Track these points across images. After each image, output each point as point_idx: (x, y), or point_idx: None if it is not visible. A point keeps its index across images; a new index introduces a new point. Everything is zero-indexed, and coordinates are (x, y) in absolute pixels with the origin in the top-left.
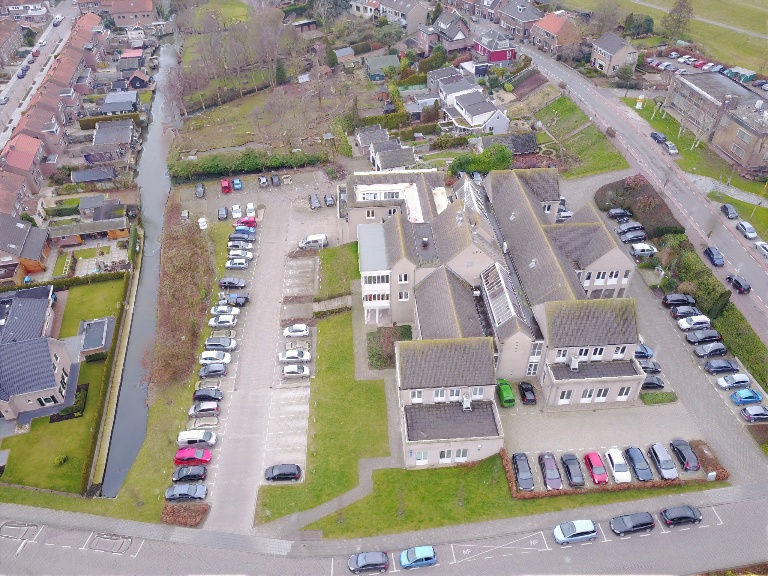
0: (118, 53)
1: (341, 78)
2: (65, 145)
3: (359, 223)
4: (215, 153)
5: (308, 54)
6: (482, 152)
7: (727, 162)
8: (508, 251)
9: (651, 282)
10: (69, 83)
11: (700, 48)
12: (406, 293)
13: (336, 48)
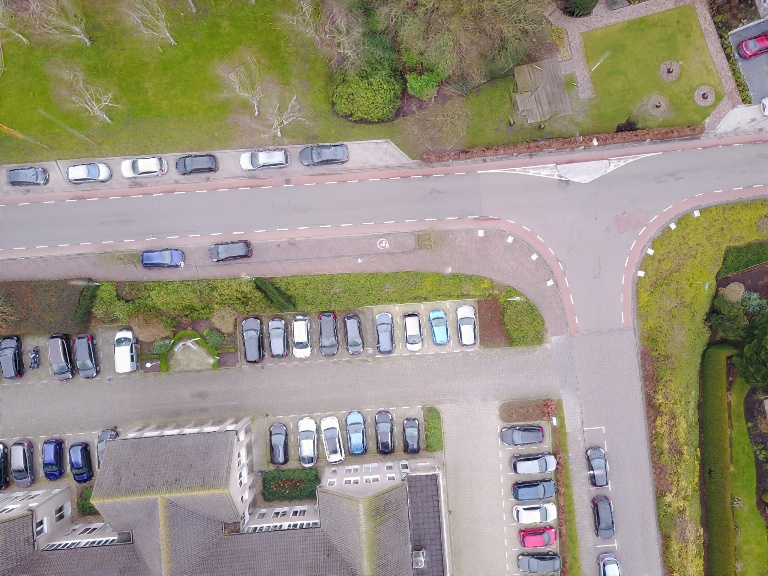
0: None
1: None
2: None
3: None
4: None
5: None
6: None
7: None
8: None
9: (203, 363)
10: None
11: None
12: None
13: None
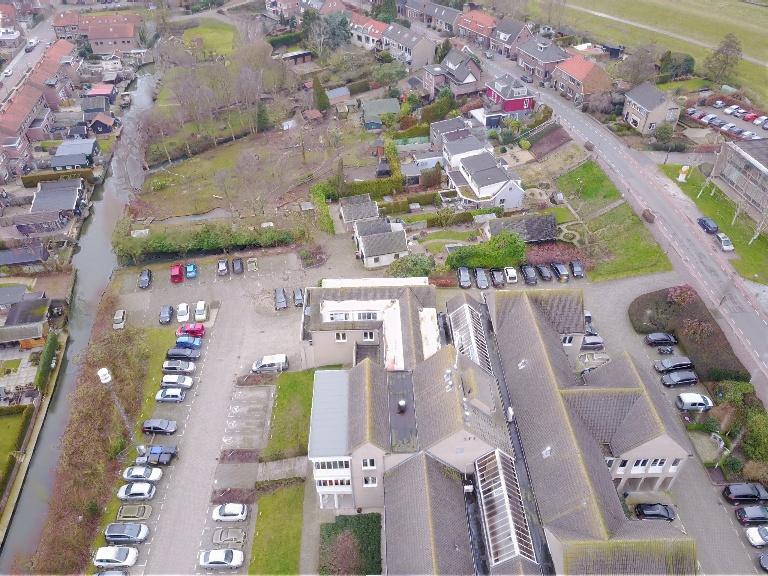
0: (87, 87)
1: (331, 127)
2: (0, 209)
3: (327, 346)
4: (173, 223)
5: (299, 93)
6: (489, 238)
7: None
8: (514, 419)
9: (706, 456)
10: (19, 129)
11: (749, 95)
12: (374, 478)
13: (330, 86)
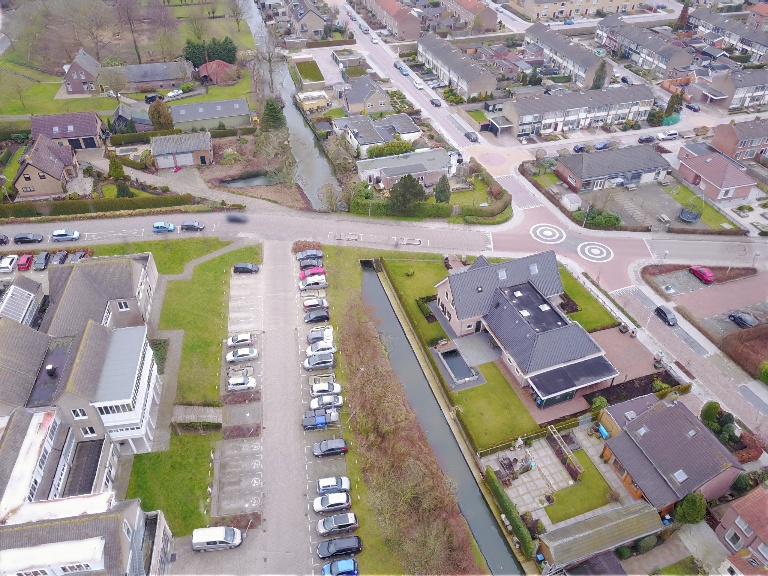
0: None
1: None
2: None
3: None
4: None
5: None
6: None
7: None
8: None
9: None
10: None
11: None
12: None
13: None
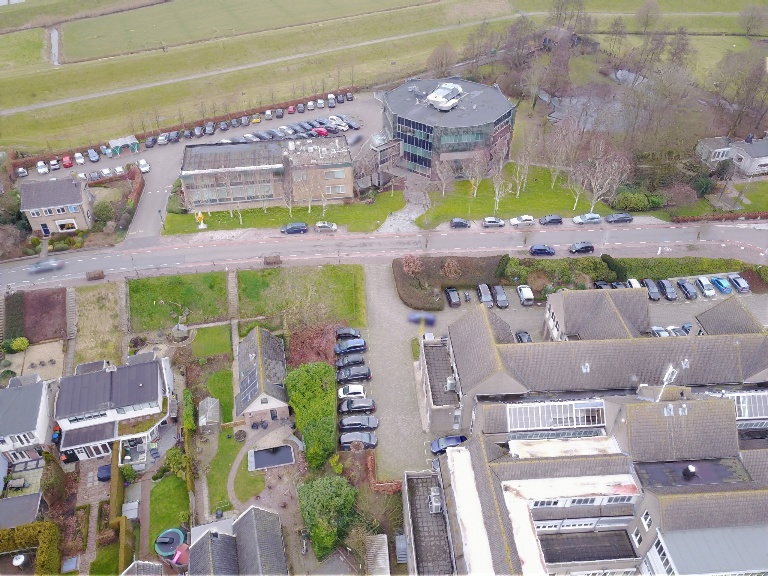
0: None
1: None
2: None
3: None
4: None
5: None
6: None
7: (338, 204)
8: None
9: None
10: None
11: None
12: None
13: None
